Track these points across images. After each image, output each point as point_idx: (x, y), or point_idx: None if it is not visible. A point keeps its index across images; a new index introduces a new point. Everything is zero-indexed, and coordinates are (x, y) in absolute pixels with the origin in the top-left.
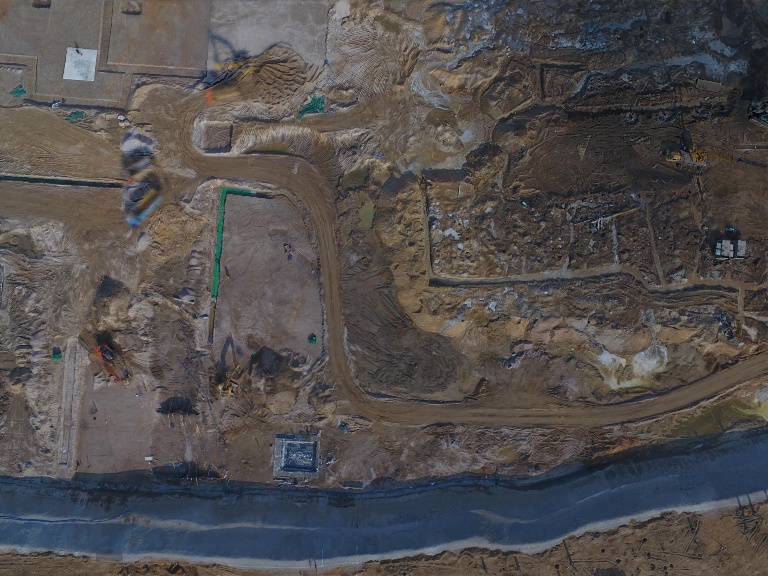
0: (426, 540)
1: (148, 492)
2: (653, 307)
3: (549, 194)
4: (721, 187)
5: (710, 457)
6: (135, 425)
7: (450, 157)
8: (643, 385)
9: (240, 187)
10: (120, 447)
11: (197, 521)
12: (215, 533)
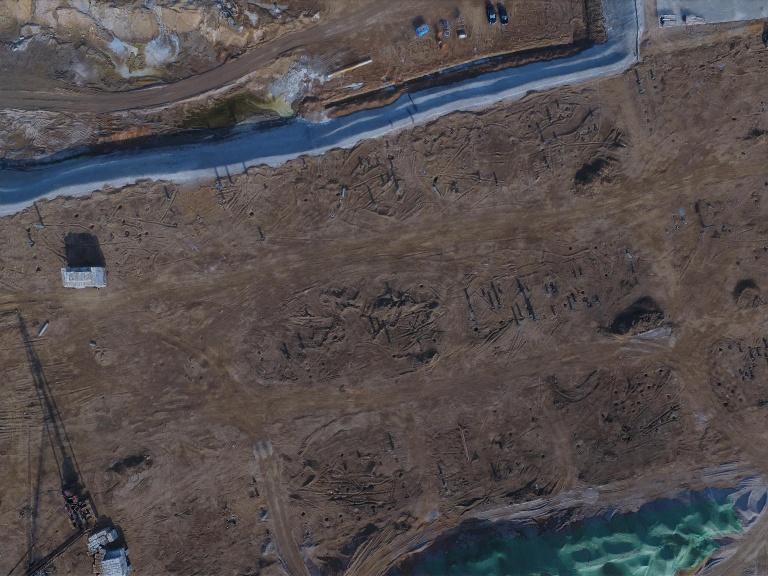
0: None
1: None
2: None
3: None
4: None
5: (214, 144)
6: None
7: None
8: (155, 75)
9: None
10: None
11: None
12: None
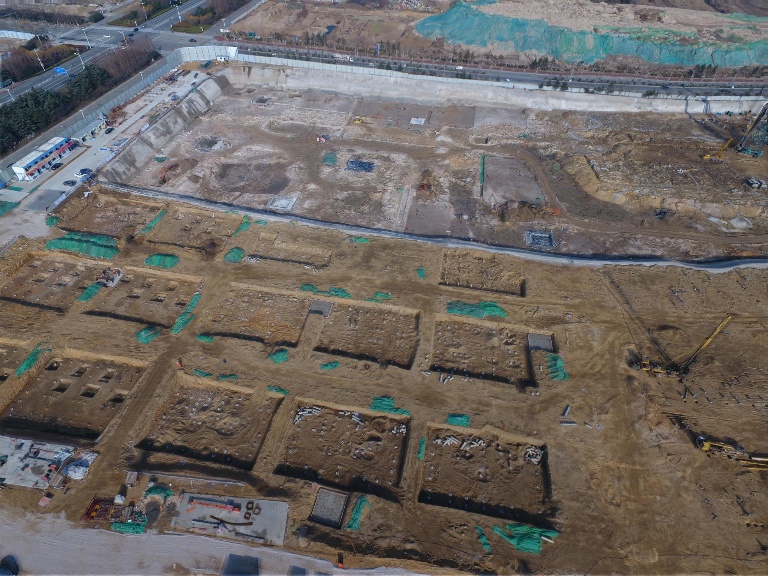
0: None
1: None
2: (728, 199)
3: None
4: None
5: None
6: (440, 219)
7: None
8: (744, 232)
9: (492, 154)
10: (431, 226)
11: None
12: None
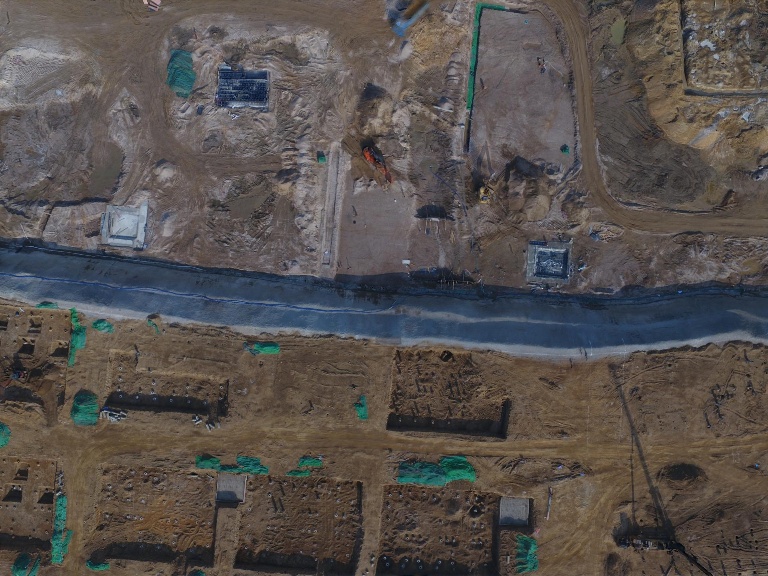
0: (690, 333)
1: (407, 293)
2: None
3: None
4: None
5: None
6: (393, 229)
7: None
8: None
9: (496, 1)
10: (379, 250)
11: (464, 314)
12: (483, 325)
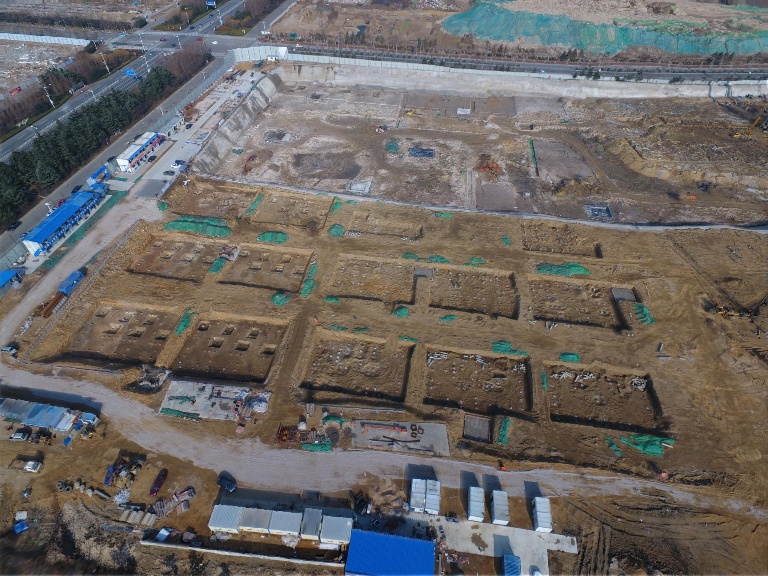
0: None
1: None
2: (762, 172)
3: None
4: (766, 145)
5: None
6: (505, 196)
7: None
8: None
9: (539, 139)
10: None
11: None
12: None
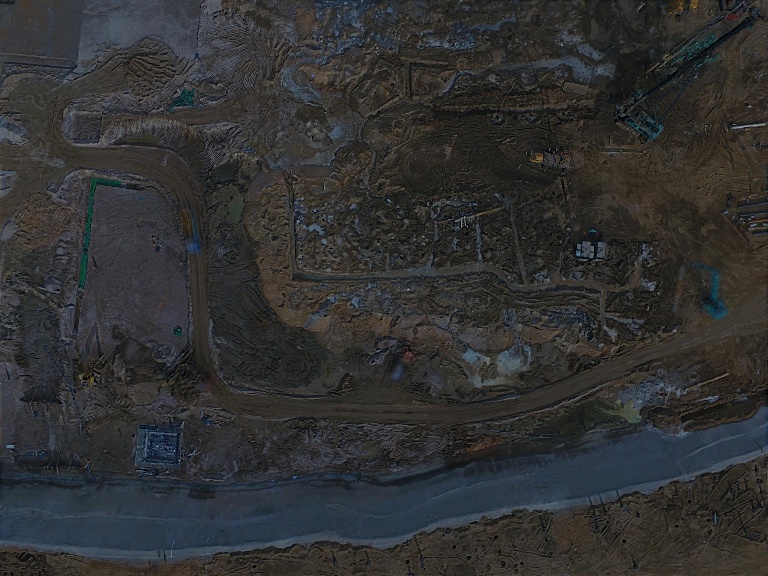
0: (277, 533)
1: (8, 480)
2: (515, 306)
3: (414, 192)
4: (585, 189)
5: (570, 456)
6: None
7: (319, 153)
8: (507, 384)
9: (109, 178)
10: None
11: (51, 510)
12: (68, 522)
